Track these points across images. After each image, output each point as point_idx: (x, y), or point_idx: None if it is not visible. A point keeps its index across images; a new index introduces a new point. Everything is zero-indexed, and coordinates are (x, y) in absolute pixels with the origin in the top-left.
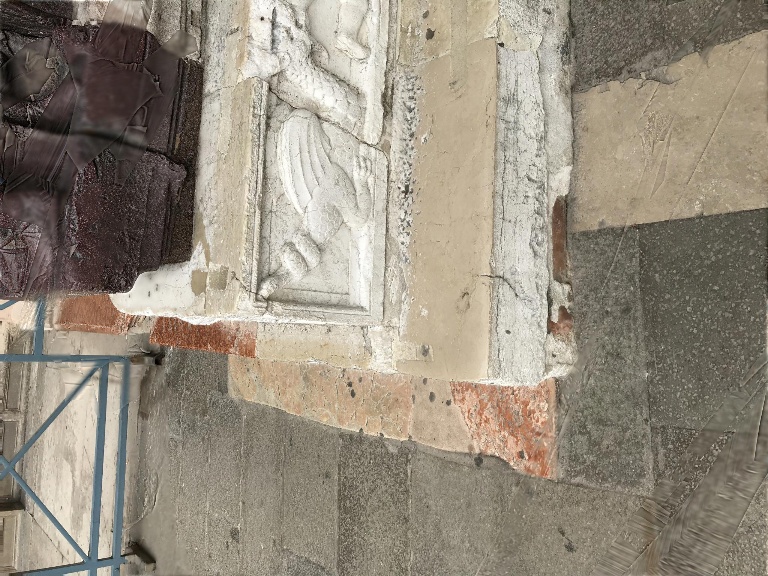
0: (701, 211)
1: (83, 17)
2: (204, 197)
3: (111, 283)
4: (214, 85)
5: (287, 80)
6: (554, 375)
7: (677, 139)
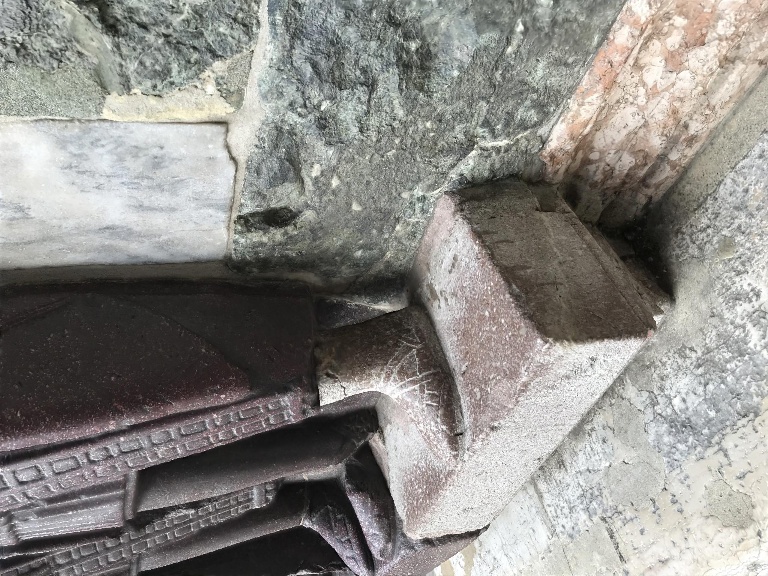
0: None
1: (394, 489)
2: (484, 550)
3: None
4: (552, 512)
5: None
6: None
7: None
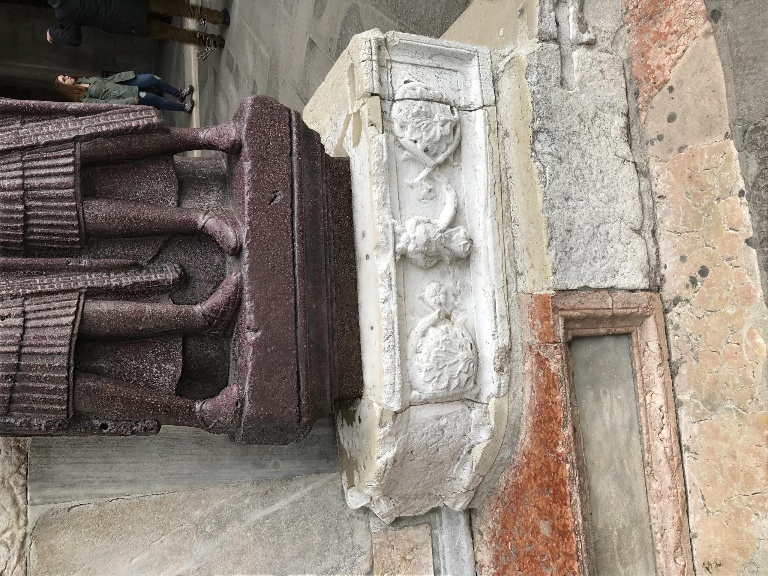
0: None
1: None
2: (328, 150)
3: None
4: None
5: None
6: None
7: None
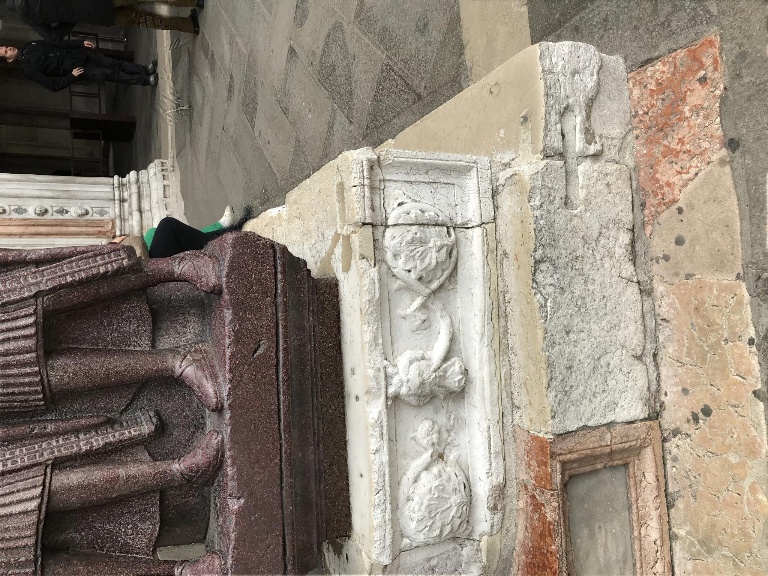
0: (525, 6)
1: None
2: (314, 258)
3: None
4: None
5: None
6: None
7: None
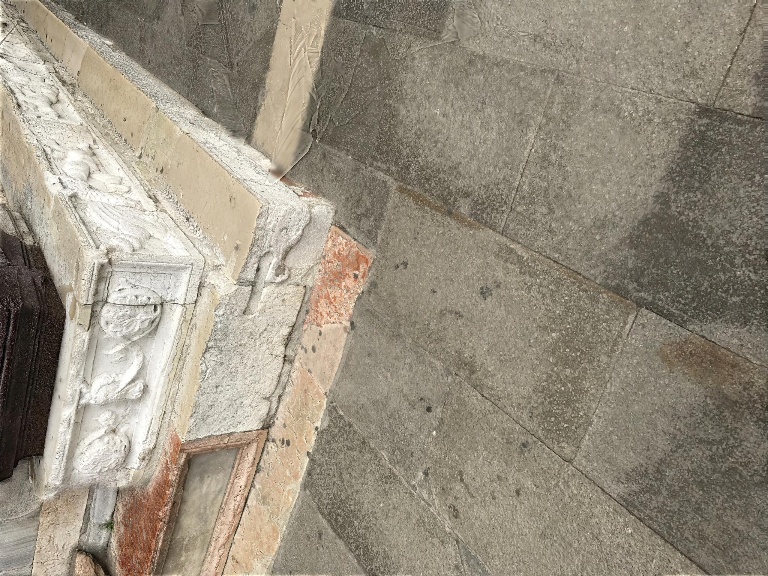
0: None
1: None
2: (59, 275)
3: (2, 303)
4: (45, 236)
5: (82, 200)
6: (322, 212)
7: (201, 5)
